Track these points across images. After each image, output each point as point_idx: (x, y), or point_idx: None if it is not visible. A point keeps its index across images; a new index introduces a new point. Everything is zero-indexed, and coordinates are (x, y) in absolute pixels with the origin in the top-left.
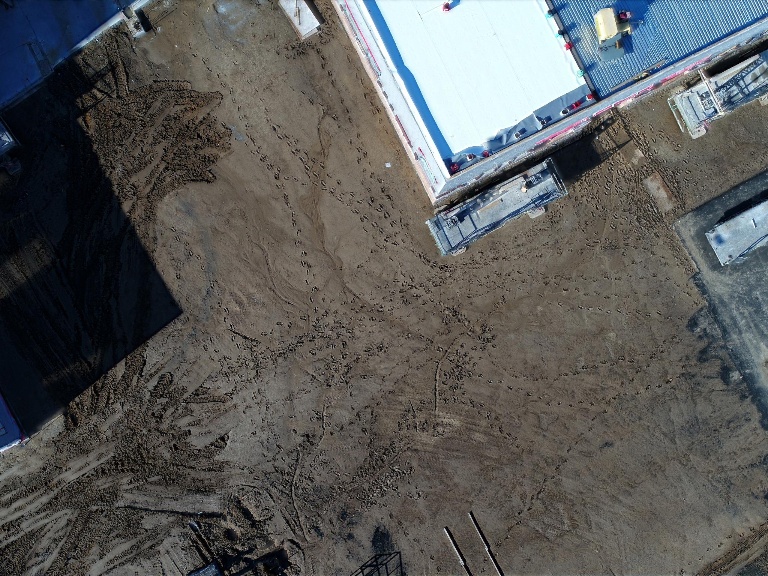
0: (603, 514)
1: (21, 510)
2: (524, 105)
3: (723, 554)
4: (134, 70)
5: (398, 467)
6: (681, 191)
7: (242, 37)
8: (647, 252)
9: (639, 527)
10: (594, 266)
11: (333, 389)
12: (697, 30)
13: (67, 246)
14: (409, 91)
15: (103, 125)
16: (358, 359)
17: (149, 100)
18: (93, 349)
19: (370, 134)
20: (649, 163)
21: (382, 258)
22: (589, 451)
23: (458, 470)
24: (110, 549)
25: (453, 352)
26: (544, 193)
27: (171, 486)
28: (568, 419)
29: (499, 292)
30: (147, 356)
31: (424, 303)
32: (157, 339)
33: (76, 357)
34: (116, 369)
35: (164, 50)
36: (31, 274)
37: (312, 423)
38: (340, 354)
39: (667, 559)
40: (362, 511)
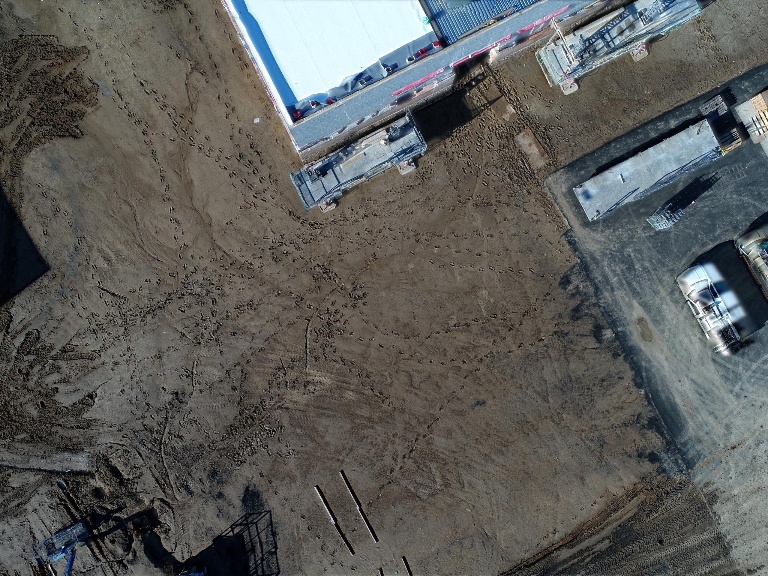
0: (475, 473)
1: None
2: (370, 52)
3: (596, 513)
4: None
5: (268, 425)
6: (553, 147)
7: None
8: (519, 209)
9: (512, 486)
10: (466, 223)
11: (203, 347)
12: None
13: None
14: (251, 37)
15: None
16: (228, 316)
17: (15, 55)
18: None
19: (238, 89)
20: (521, 119)
21: (251, 215)
22: (461, 409)
23: (329, 428)
24: None
25: (324, 310)
26: (407, 147)
27: (38, 444)
28: (440, 377)
29: (370, 249)
30: (14, 313)
31: (294, 260)
32: (24, 296)
33: None
34: None
35: (30, 4)
36: None
37: (181, 381)
38: (209, 311)
39: (540, 518)
40: (232, 469)
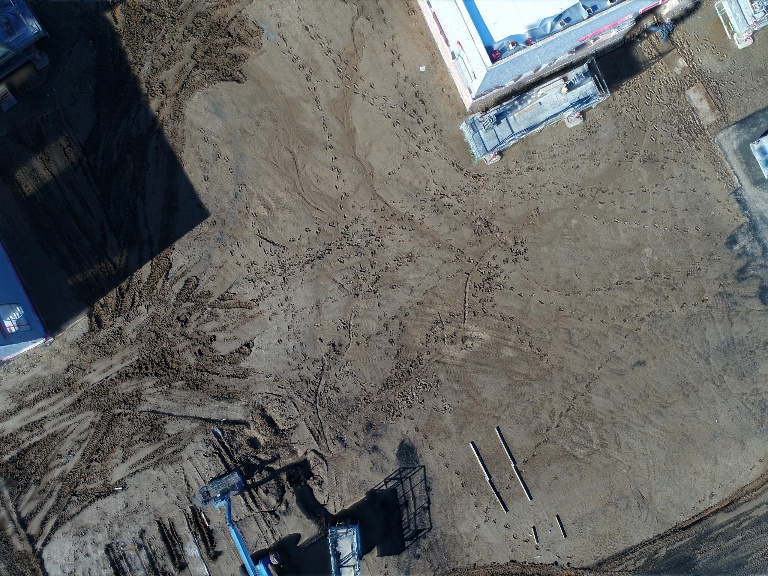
0: (633, 434)
1: (44, 411)
2: None
3: (755, 478)
4: None
5: (425, 380)
6: (725, 103)
7: None
8: (687, 165)
9: (669, 448)
10: (632, 179)
11: (361, 298)
12: None
13: (94, 144)
14: None
15: (133, 21)
16: (387, 268)
17: None
18: (119, 250)
19: (405, 36)
20: (692, 73)
21: (414, 165)
22: (620, 369)
23: (486, 384)
24: (132, 453)
25: (484, 264)
26: (584, 97)
27: (195, 392)
28: (600, 336)
29: (533, 203)
30: (173, 259)
31: (456, 213)
32: (183, 242)
33: (101, 258)
34: (142, 271)
35: None
36: (58, 172)
37: (338, 332)
38: (369, 263)
39: (697, 481)
40: (387, 423)
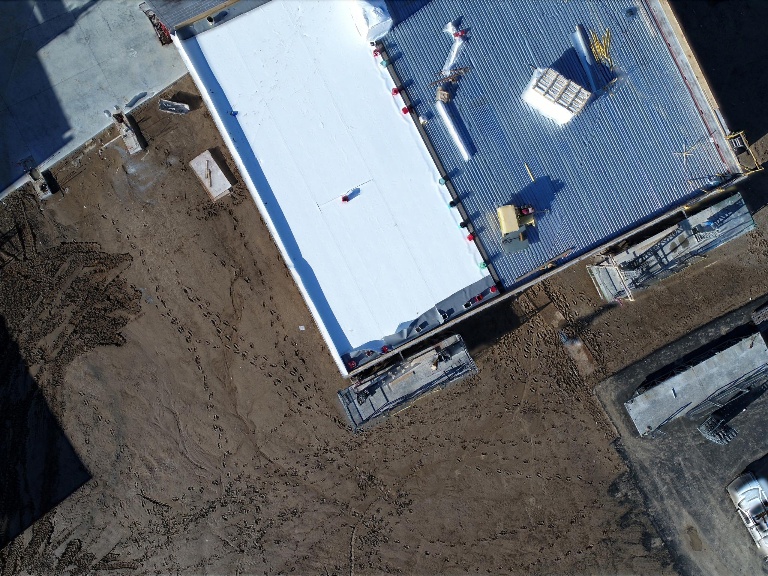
0: None
1: None
2: (426, 297)
3: None
4: (42, 232)
5: None
6: (602, 354)
7: (152, 198)
8: (567, 416)
9: None
10: (513, 430)
11: (246, 555)
12: (605, 218)
13: None
14: (306, 286)
15: (10, 287)
16: (272, 524)
17: (57, 262)
18: None
19: (283, 297)
20: (570, 326)
21: (296, 422)
22: None
23: None
24: None
25: (369, 517)
26: (457, 366)
27: None
28: None
29: (416, 456)
30: (55, 523)
31: (339, 467)
32: (65, 505)
33: None
34: (23, 536)
35: (72, 211)
36: None
37: None
38: (253, 519)
39: None
40: None
